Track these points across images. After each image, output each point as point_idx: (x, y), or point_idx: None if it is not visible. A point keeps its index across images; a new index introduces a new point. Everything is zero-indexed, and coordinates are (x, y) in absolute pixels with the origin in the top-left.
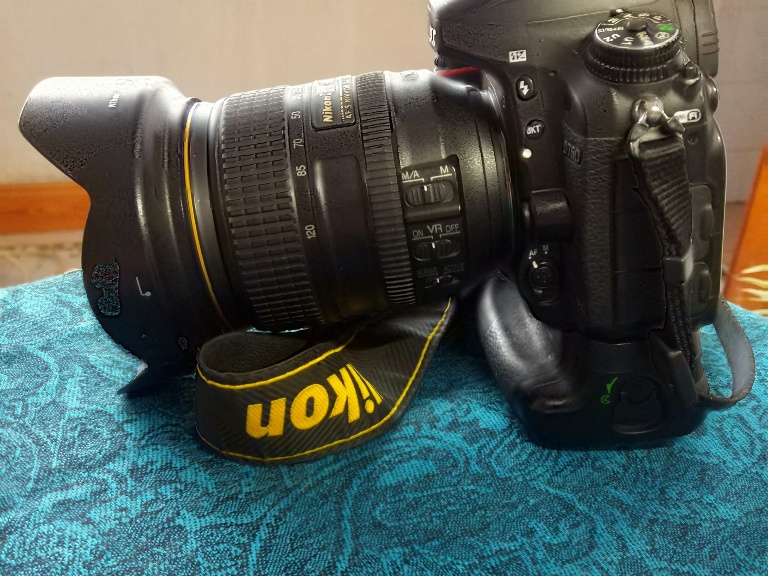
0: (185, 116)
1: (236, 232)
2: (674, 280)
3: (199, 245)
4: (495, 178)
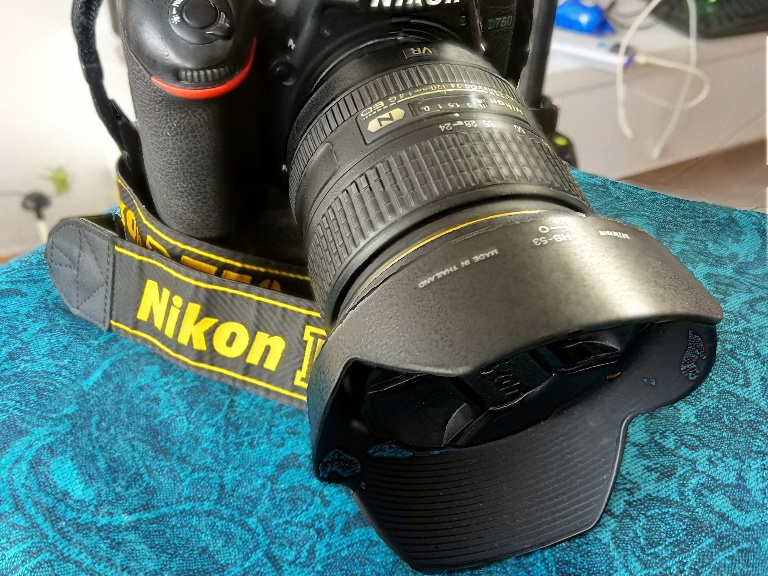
0: None
1: None
2: None
3: None
4: None
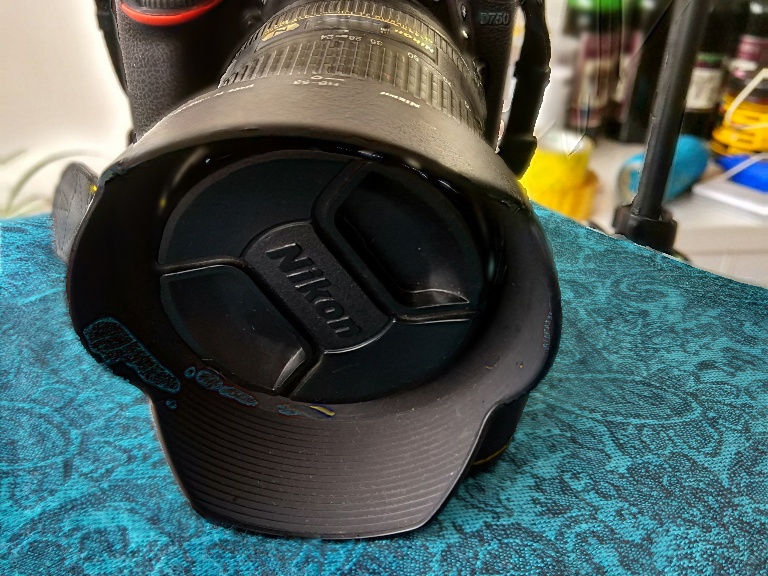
0: None
1: None
2: None
3: None
4: None
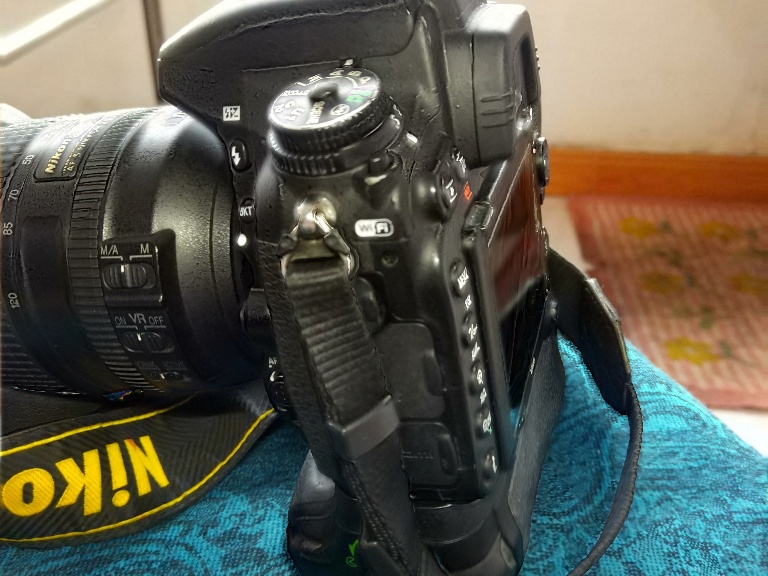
0: None
1: None
2: (341, 453)
3: None
4: (226, 262)
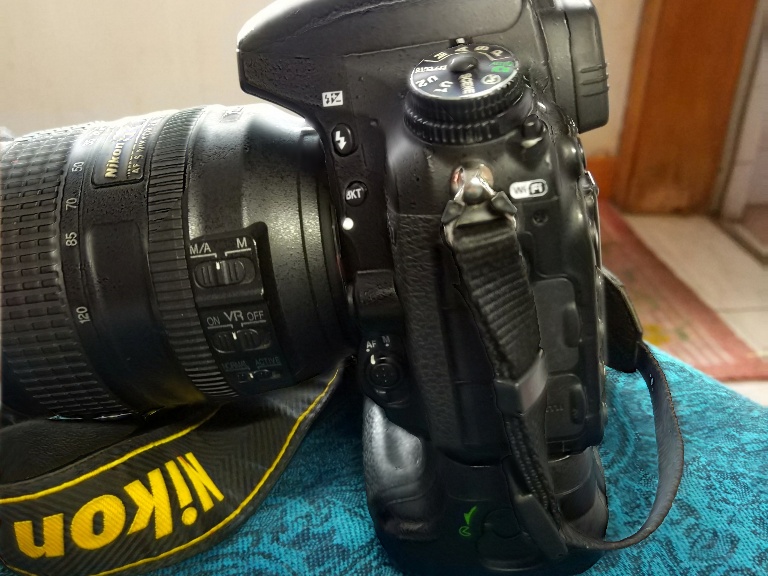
0: None
1: None
2: (509, 408)
3: None
4: (319, 250)
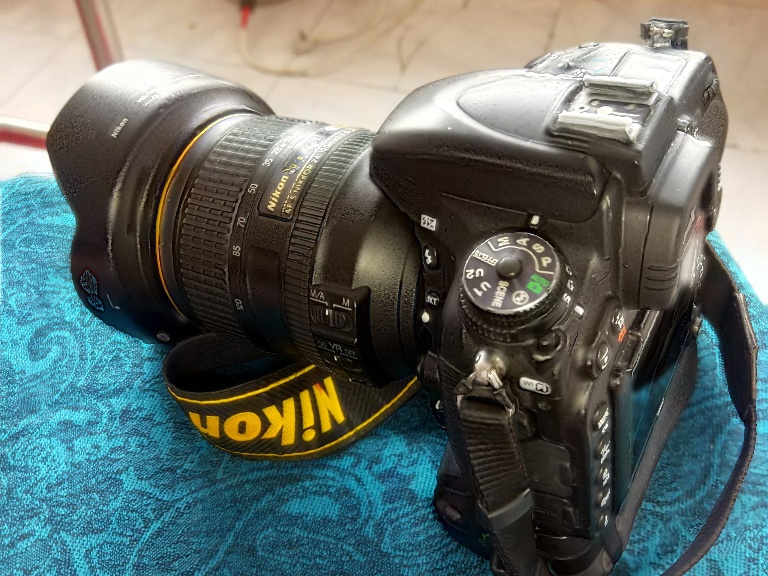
0: (182, 149)
1: (186, 281)
2: None
3: (163, 278)
4: (410, 316)
